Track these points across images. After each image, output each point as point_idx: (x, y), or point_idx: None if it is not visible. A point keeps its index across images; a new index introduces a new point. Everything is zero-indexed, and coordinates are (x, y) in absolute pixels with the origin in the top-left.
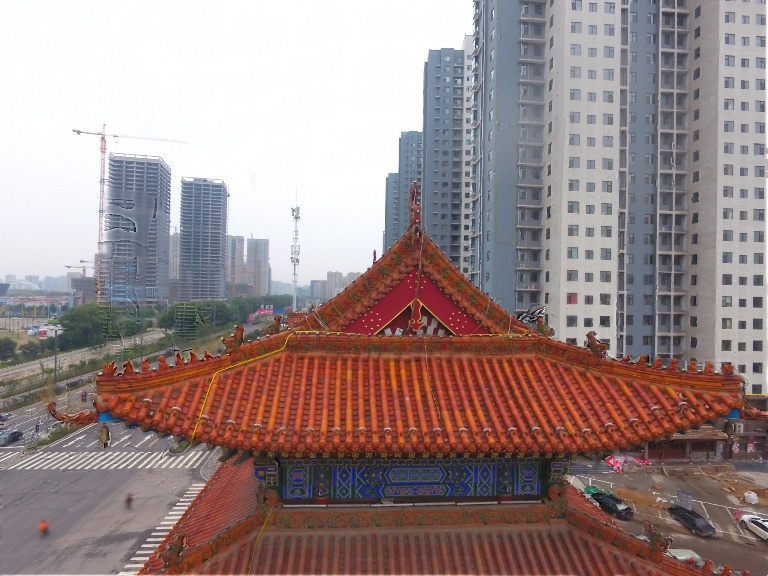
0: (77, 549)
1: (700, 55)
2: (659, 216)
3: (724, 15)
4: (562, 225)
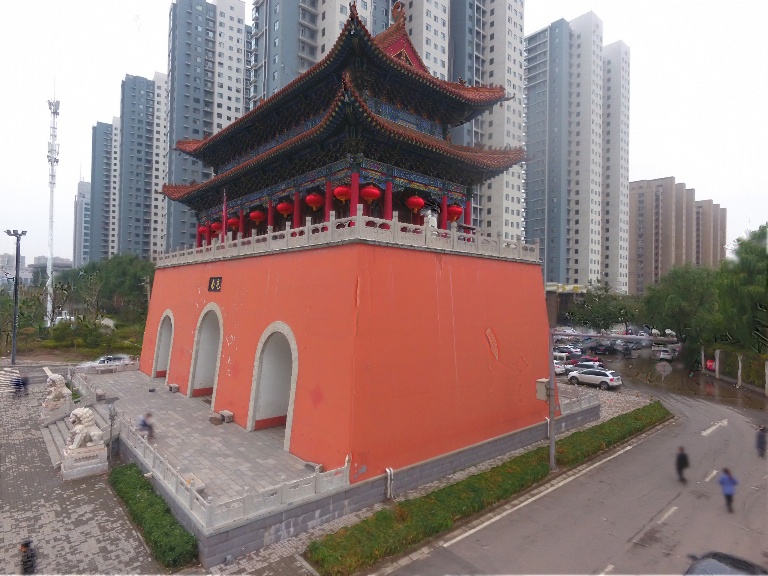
0: None
1: None
2: None
3: (425, 39)
4: None
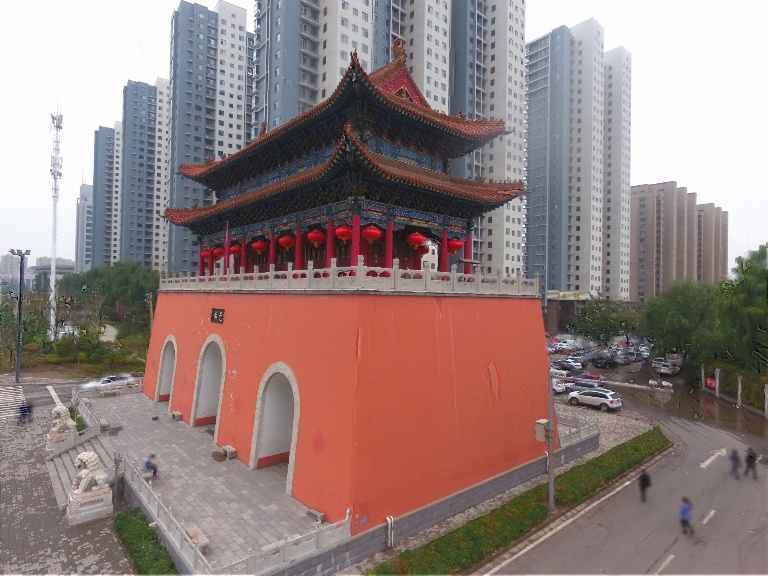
0: None
1: (413, 71)
2: None
3: (426, 49)
4: None
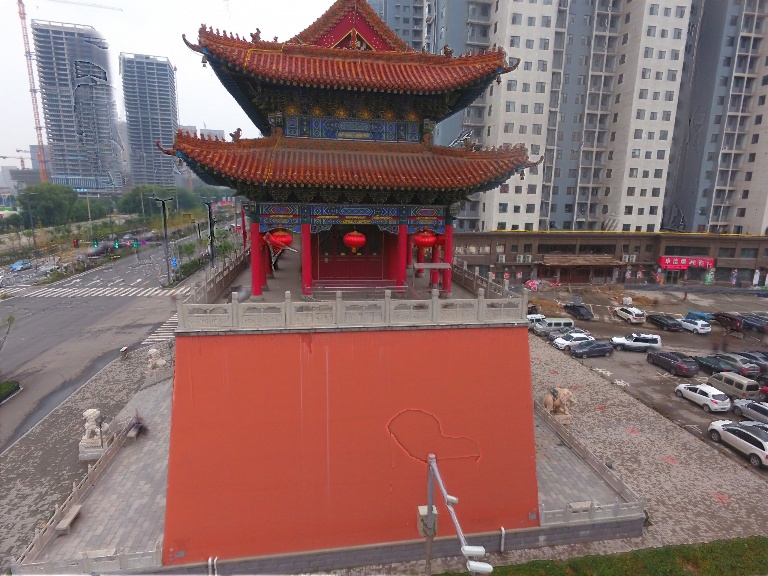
0: (106, 331)
1: None
2: (590, 77)
3: None
4: (503, 80)
